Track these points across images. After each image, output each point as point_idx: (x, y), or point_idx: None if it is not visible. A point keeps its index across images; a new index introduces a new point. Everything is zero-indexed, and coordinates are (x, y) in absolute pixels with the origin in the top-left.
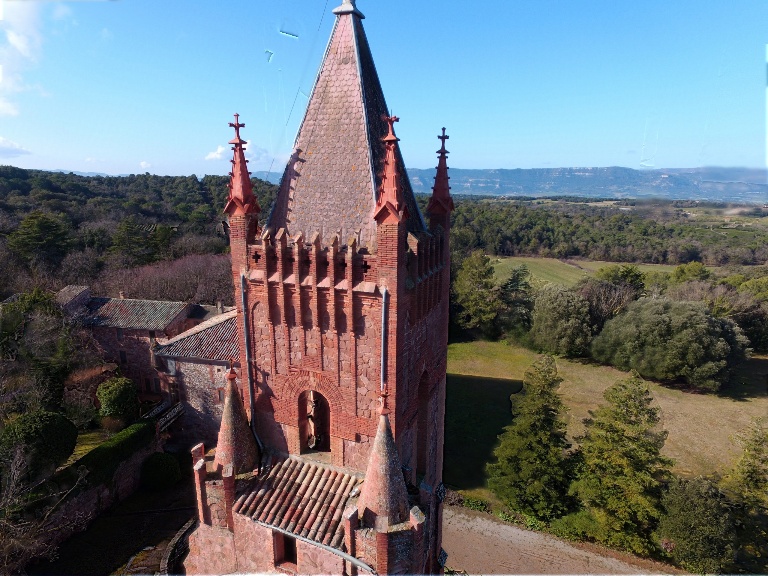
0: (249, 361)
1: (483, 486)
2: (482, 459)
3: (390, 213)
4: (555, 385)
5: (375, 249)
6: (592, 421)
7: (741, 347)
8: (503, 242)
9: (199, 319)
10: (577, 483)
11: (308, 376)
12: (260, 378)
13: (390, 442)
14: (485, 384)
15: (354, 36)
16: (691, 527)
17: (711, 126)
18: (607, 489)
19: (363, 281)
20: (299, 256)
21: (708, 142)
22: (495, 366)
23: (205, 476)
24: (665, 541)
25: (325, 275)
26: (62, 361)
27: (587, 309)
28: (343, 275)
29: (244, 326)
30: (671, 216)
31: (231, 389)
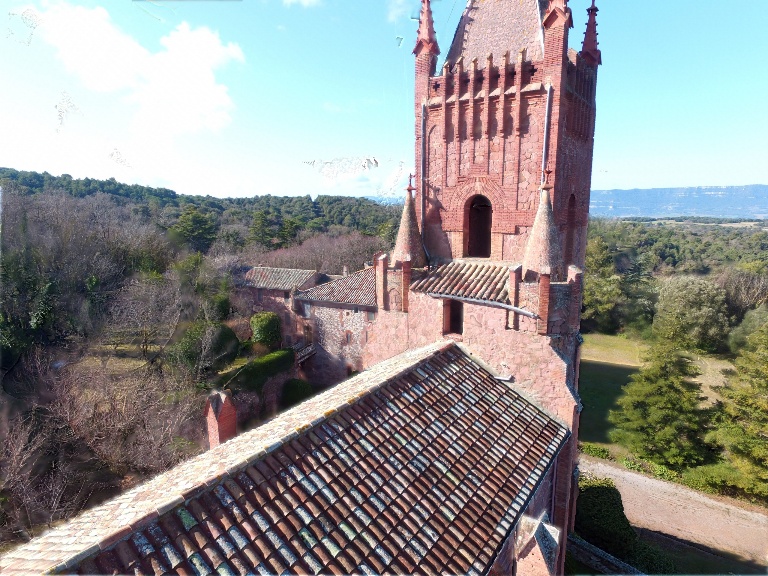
0: (423, 180)
1: (604, 441)
2: (602, 422)
3: (558, 16)
4: (689, 327)
5: None
6: (733, 372)
7: None
8: (623, 231)
9: None
10: (715, 432)
11: (475, 182)
12: (431, 194)
13: (551, 213)
14: (602, 367)
15: None
16: None
17: None
18: (752, 439)
19: (530, 83)
20: (474, 74)
21: None
22: (613, 354)
23: (387, 267)
24: None
25: (496, 86)
26: (225, 294)
27: (723, 297)
28: (512, 82)
29: (421, 149)
30: None
31: (409, 199)
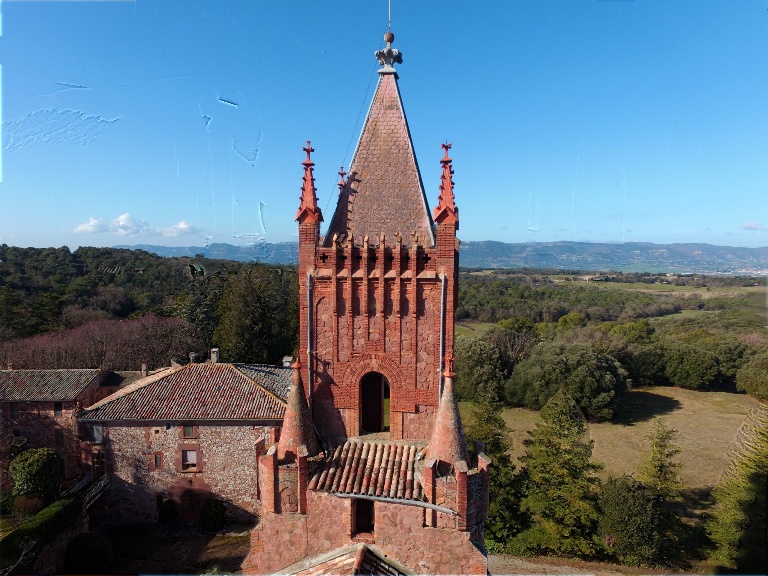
0: (311, 353)
1: None
2: None
3: (448, 215)
4: (499, 409)
5: (430, 246)
6: (531, 441)
7: (623, 379)
8: None
9: (114, 386)
10: (526, 500)
11: (370, 359)
12: (320, 368)
13: (455, 400)
14: None
15: (397, 90)
16: (626, 520)
17: (577, 199)
18: (553, 500)
19: (424, 270)
20: (368, 253)
21: (576, 211)
22: None
23: (277, 462)
24: (607, 537)
25: (390, 268)
26: None
27: (498, 355)
28: (407, 267)
29: (308, 320)
30: (556, 271)
31: (298, 378)
